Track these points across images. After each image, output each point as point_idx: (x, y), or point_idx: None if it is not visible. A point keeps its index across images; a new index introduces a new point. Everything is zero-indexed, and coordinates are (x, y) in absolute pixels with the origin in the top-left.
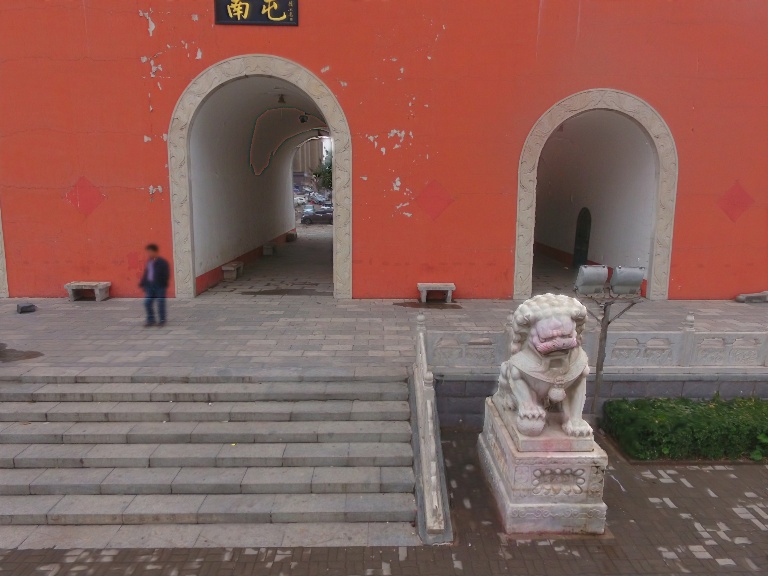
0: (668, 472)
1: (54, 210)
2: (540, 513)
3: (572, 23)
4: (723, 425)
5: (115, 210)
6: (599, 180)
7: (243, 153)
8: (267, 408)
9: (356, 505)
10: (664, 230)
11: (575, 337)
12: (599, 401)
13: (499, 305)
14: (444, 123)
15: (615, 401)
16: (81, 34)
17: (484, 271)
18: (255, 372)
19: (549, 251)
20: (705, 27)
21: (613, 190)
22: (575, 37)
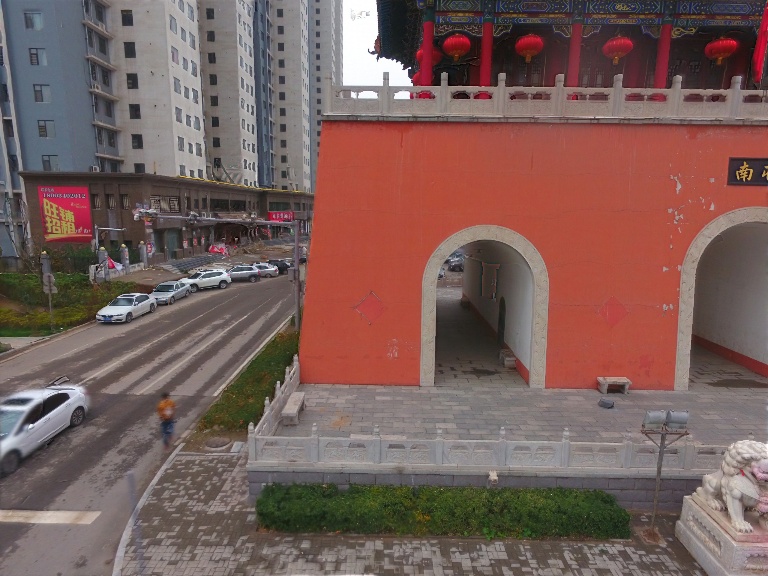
0: None
1: (588, 322)
2: None
3: None
4: None
5: (634, 322)
6: None
7: None
8: None
9: None
10: None
11: None
12: None
13: None
14: None
15: None
16: (625, 192)
17: None
18: None
19: None
20: None
21: None
22: None
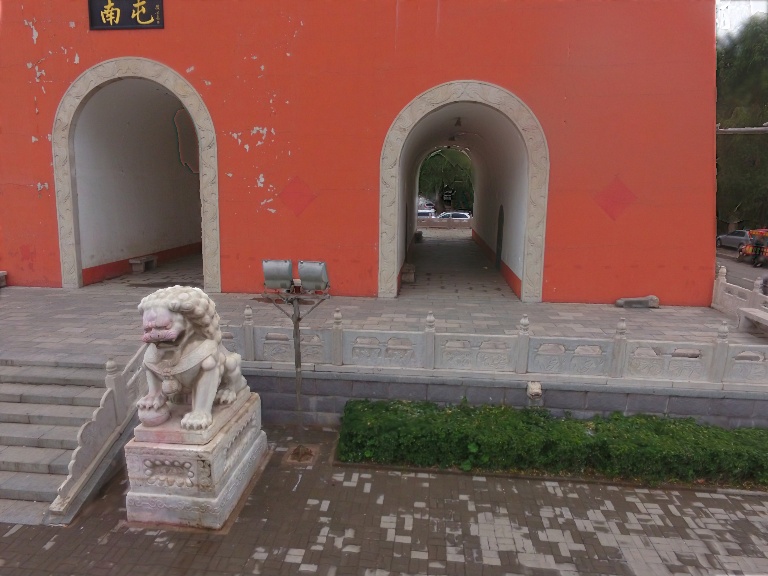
0: (361, 476)
1: None
2: (154, 503)
3: (431, 13)
4: (434, 431)
5: (10, 205)
6: (507, 176)
7: (168, 152)
8: (5, 389)
9: (13, 483)
10: (536, 228)
11: (176, 329)
12: (342, 400)
13: (354, 302)
14: (305, 119)
15: (355, 401)
16: None
17: (349, 268)
18: (22, 356)
19: (487, 250)
20: (576, 11)
21: (512, 186)
22: (435, 28)
